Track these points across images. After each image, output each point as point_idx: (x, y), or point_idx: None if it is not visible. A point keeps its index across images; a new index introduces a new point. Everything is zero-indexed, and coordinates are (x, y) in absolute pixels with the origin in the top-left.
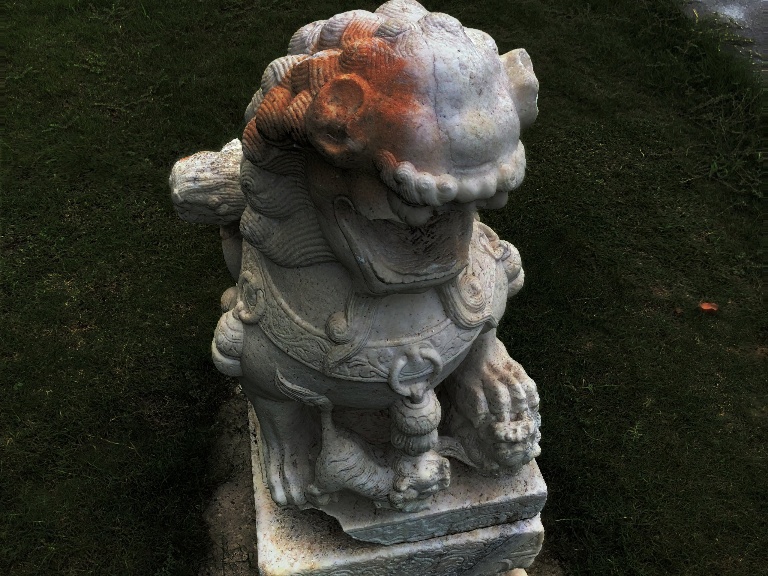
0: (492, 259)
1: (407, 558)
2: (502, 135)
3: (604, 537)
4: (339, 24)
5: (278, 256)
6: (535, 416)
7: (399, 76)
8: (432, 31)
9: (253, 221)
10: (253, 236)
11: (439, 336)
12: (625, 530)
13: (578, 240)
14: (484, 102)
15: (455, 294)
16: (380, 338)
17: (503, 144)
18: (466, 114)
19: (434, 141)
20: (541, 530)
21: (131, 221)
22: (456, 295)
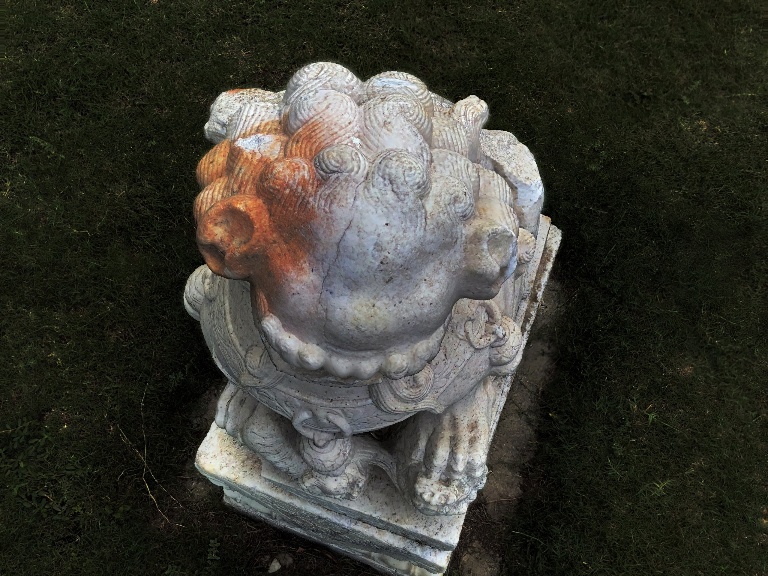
0: (471, 347)
1: (318, 516)
2: (401, 329)
3: (551, 569)
4: (305, 112)
5: None
6: (479, 480)
7: (303, 227)
8: (374, 184)
9: None
10: None
11: (353, 410)
12: (574, 575)
13: (764, 246)
14: (391, 291)
15: (382, 384)
16: (292, 387)
17: (402, 336)
18: (357, 300)
19: (308, 313)
20: (442, 565)
21: (333, 8)
22: (384, 385)
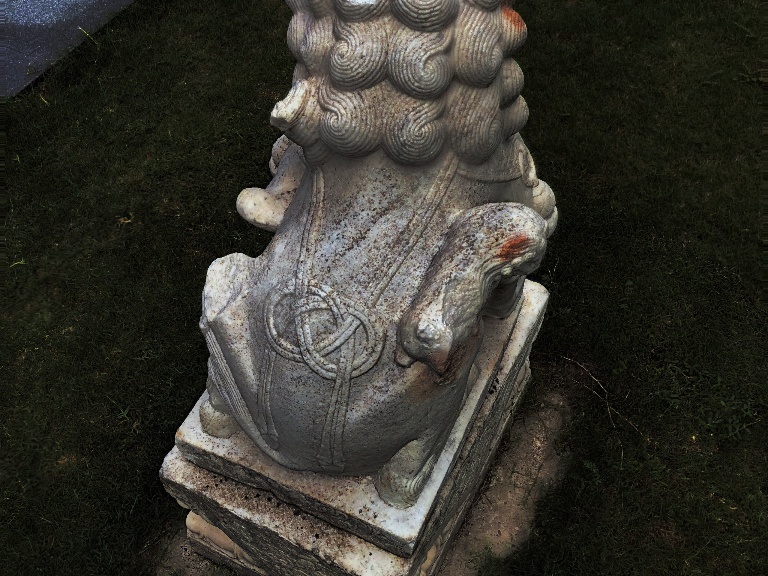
0: None
1: None
2: None
3: None
4: None
5: None
6: None
7: None
8: None
9: None
10: None
11: None
12: None
13: None
14: None
15: None
16: None
17: None
18: None
19: None
20: None
21: None
22: None
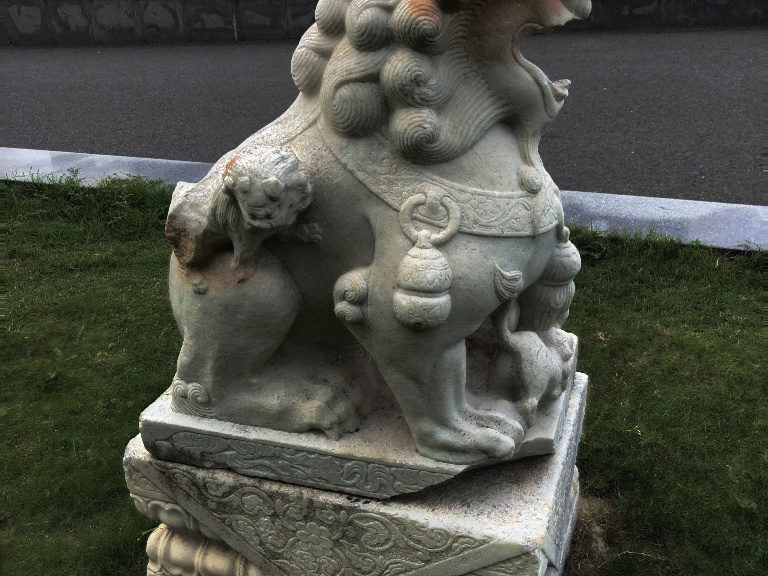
0: None
1: None
2: None
3: None
4: None
5: (455, 144)
6: None
7: None
8: None
9: (429, 116)
10: (435, 130)
11: None
12: None
13: None
14: None
15: None
16: None
17: None
18: None
19: None
20: None
21: None
22: None
